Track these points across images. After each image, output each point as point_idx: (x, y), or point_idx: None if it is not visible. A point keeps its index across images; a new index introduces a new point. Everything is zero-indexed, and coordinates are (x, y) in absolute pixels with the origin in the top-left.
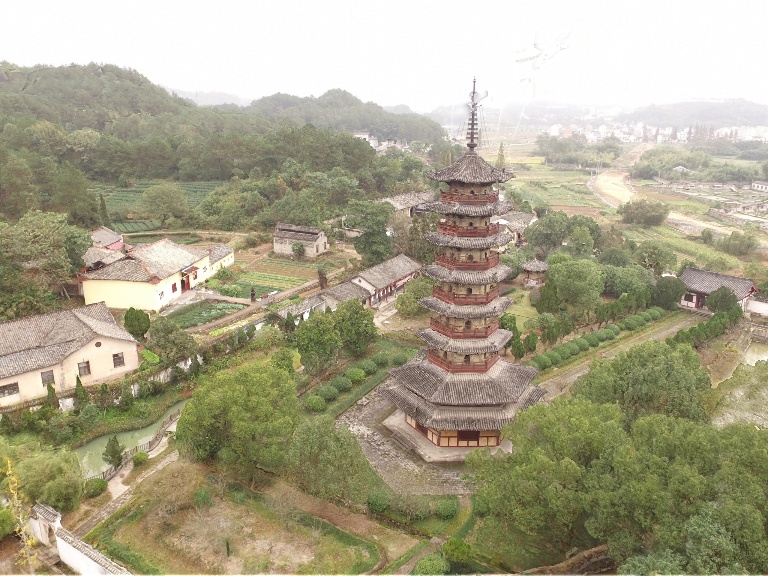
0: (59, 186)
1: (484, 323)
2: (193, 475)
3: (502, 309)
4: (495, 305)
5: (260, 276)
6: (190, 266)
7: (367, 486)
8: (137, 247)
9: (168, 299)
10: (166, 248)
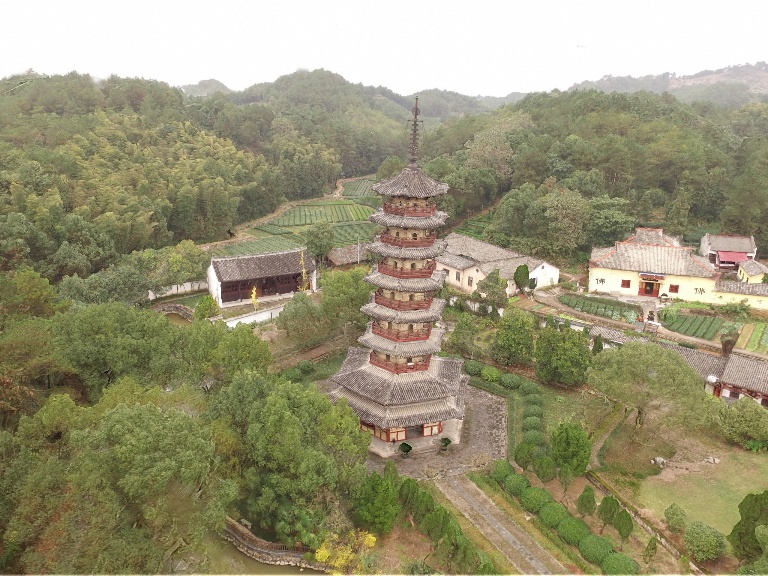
0: (728, 188)
1: (389, 326)
2: (318, 300)
3: (381, 316)
4: (386, 312)
5: (765, 331)
6: (659, 274)
7: (329, 370)
8: (743, 262)
9: (612, 289)
10: (667, 253)
